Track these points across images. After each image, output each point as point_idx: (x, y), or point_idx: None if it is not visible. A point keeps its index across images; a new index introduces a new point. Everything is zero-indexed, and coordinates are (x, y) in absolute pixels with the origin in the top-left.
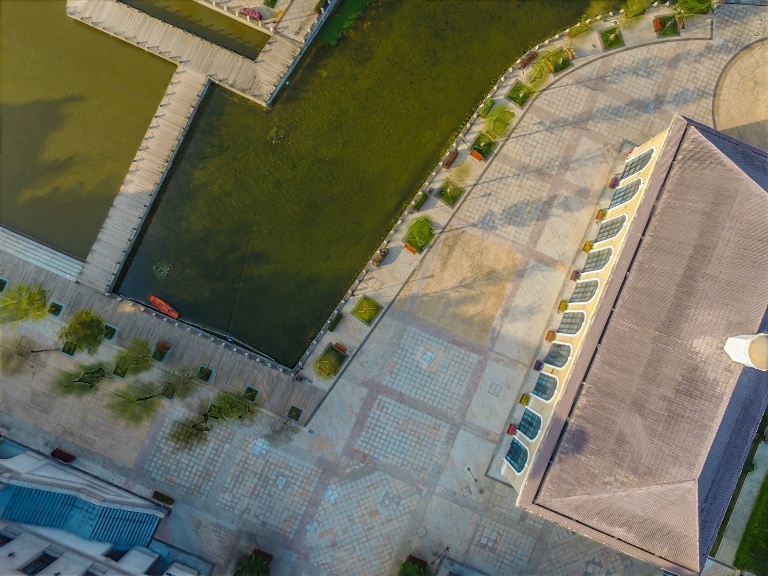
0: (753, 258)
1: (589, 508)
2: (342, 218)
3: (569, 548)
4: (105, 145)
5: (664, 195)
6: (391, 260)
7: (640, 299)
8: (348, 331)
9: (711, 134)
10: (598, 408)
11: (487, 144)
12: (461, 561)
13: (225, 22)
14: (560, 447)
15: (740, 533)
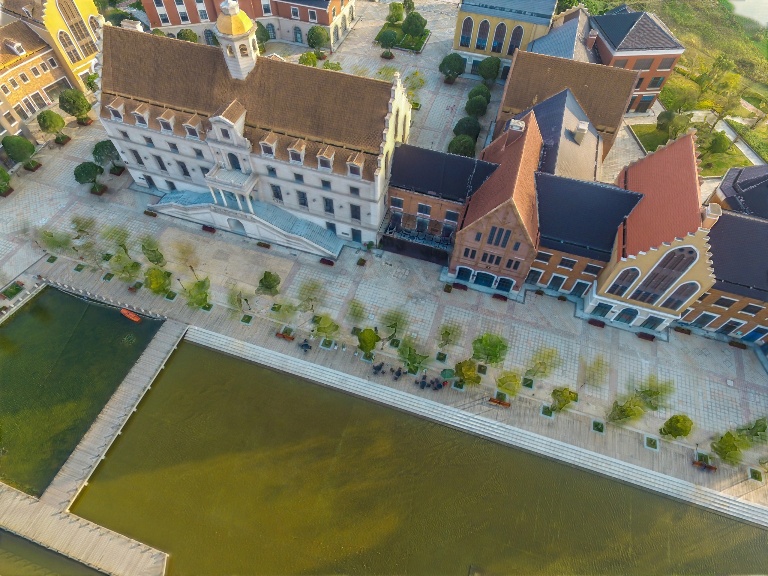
0: None
1: None
2: None
3: None
4: (157, 431)
5: None
6: None
7: None
8: None
9: None
10: None
11: None
12: None
13: (11, 572)
14: None
15: None
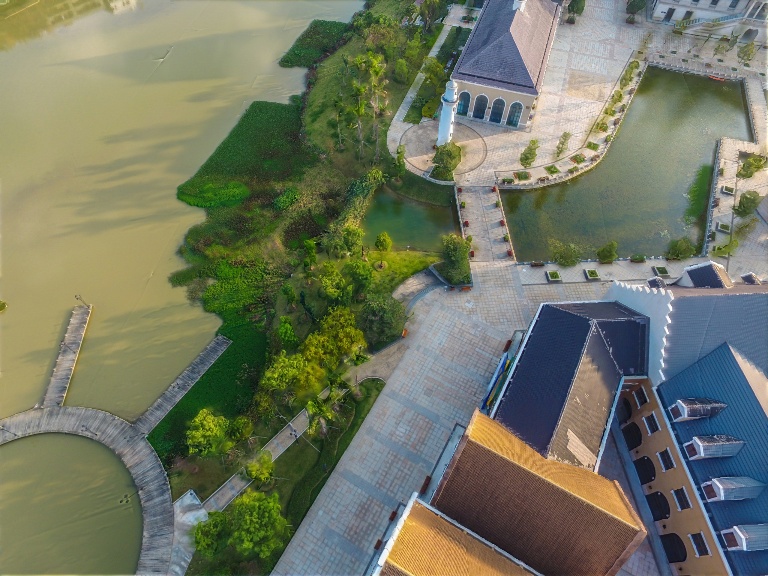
0: None
1: None
2: (655, 107)
3: None
4: None
5: None
6: None
7: None
8: None
9: (525, 84)
10: None
11: None
12: None
13: None
14: None
15: None
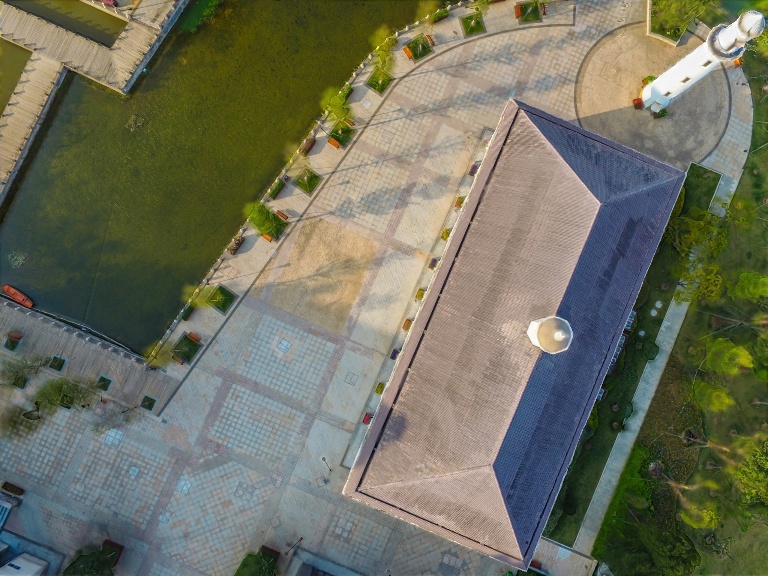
0: (559, 241)
1: (407, 495)
2: (201, 206)
3: (425, 538)
4: None
5: (492, 180)
6: (247, 248)
7: (463, 284)
8: (203, 320)
9: (541, 118)
10: (418, 394)
11: (345, 131)
12: (315, 552)
13: (84, 9)
14: (383, 434)
15: (598, 523)
